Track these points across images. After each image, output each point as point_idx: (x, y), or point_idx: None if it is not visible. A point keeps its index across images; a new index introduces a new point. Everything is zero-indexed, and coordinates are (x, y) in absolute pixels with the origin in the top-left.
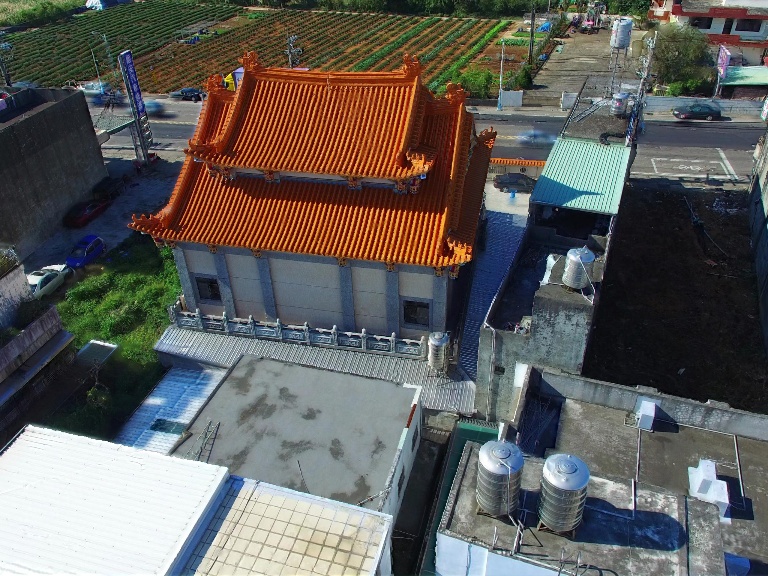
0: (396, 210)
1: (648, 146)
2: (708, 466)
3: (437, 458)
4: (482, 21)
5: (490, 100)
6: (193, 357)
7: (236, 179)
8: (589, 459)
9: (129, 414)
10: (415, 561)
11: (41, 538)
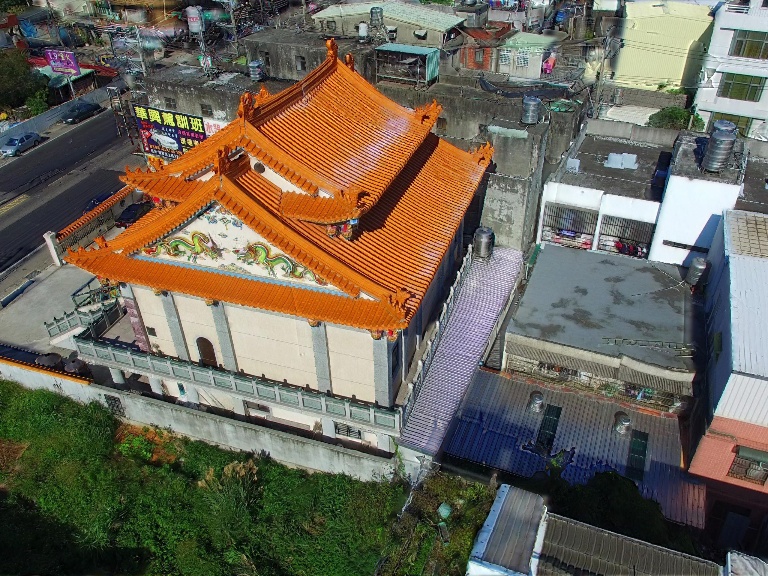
0: (427, 162)
1: (118, 147)
2: (614, 154)
3: None
4: None
5: None
6: (454, 415)
7: None
8: (607, 188)
9: None
10: None
11: None
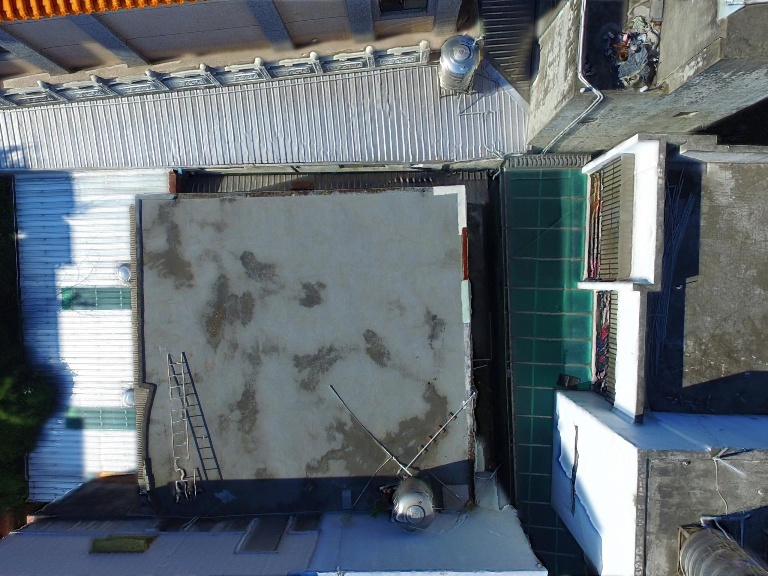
0: None
1: None
2: None
3: (484, 232)
4: None
5: None
6: (40, 168)
7: None
8: (750, 281)
9: (14, 291)
10: (503, 406)
11: None
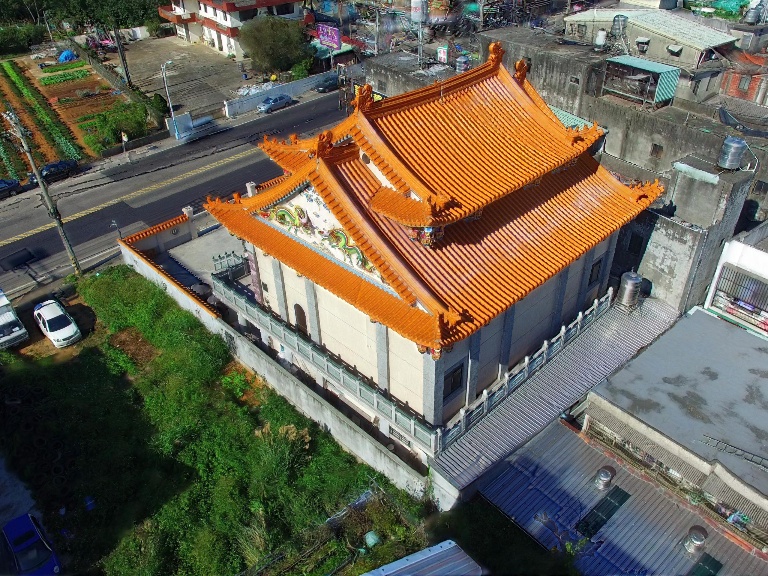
0: None
1: None
2: None
3: None
4: None
5: (161, 133)
6: (502, 457)
7: None
8: None
9: None
10: None
11: None
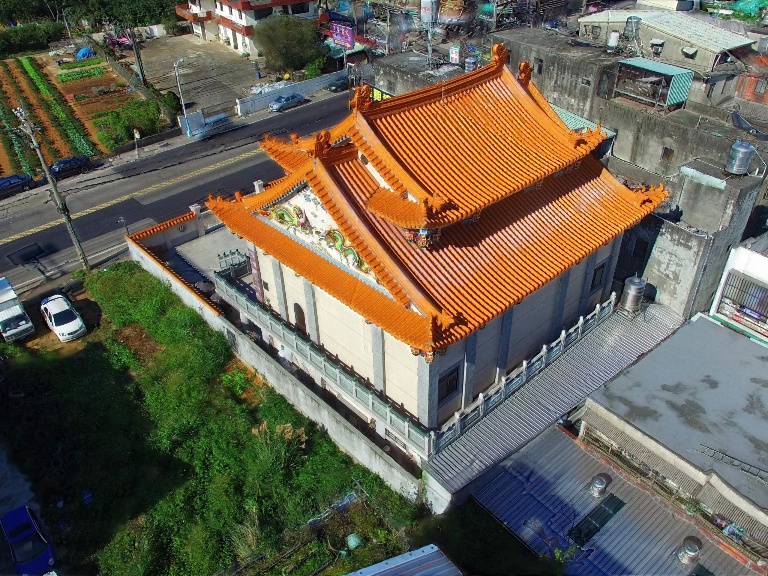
0: (574, 190)
1: None
2: None
3: None
4: None
5: (173, 130)
6: (496, 462)
7: None
8: None
9: None
10: None
11: None
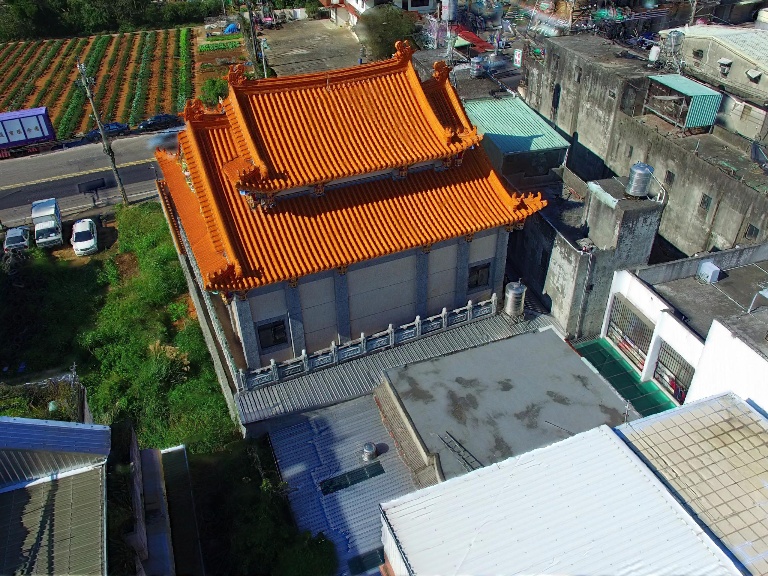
0: (449, 186)
1: None
2: None
3: None
4: (159, 32)
5: None
6: (296, 410)
7: (276, 205)
8: (713, 314)
9: None
10: None
11: (556, 567)
